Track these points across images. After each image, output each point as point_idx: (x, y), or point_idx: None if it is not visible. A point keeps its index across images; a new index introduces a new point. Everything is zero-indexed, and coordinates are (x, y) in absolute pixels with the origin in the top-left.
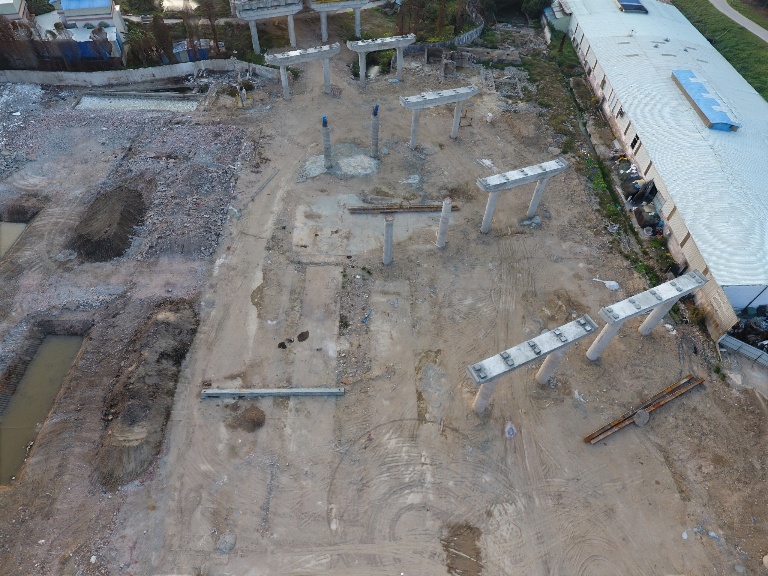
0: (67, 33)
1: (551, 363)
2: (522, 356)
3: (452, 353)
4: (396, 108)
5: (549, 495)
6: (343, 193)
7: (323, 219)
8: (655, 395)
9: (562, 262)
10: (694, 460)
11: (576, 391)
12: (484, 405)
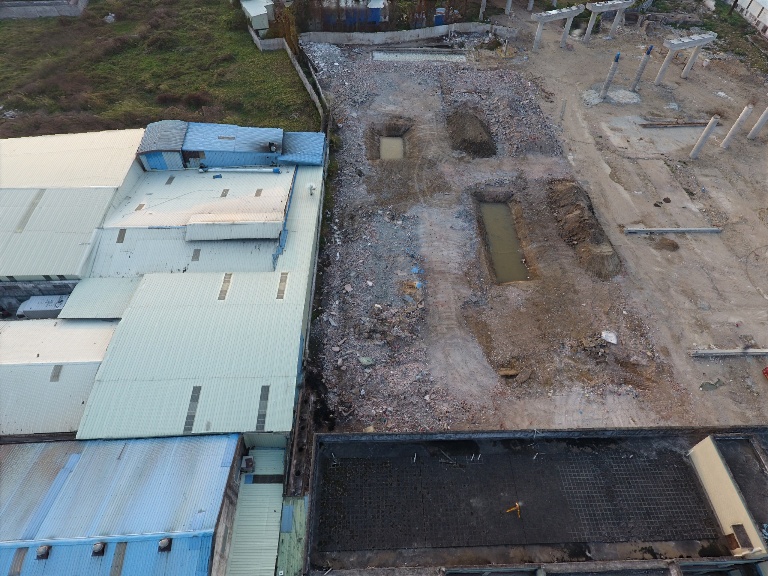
0: None
1: None
2: None
3: None
4: (624, 57)
5: None
6: (627, 115)
7: (625, 131)
8: None
9: None
10: None
11: None
12: None
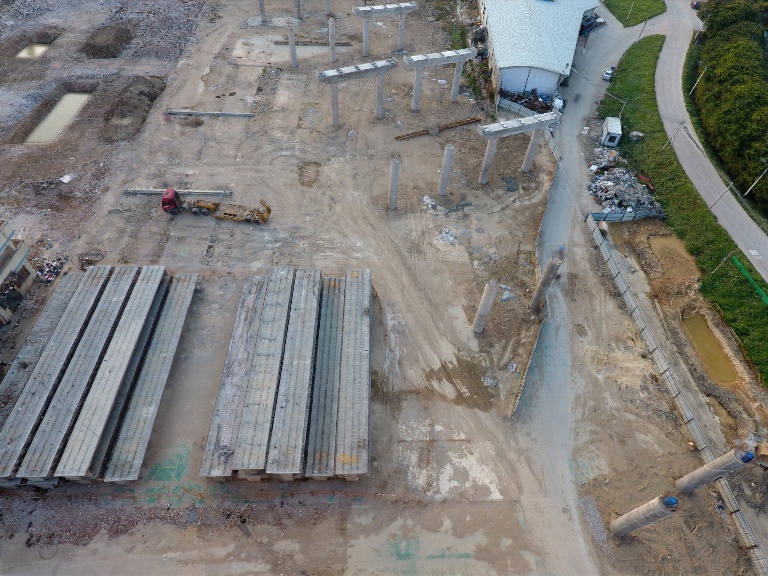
0: None
1: (378, 94)
2: (349, 70)
3: (326, 104)
4: None
5: (366, 155)
6: (272, 34)
7: (255, 46)
8: (447, 124)
9: (413, 71)
10: (459, 148)
11: (399, 121)
12: (336, 117)
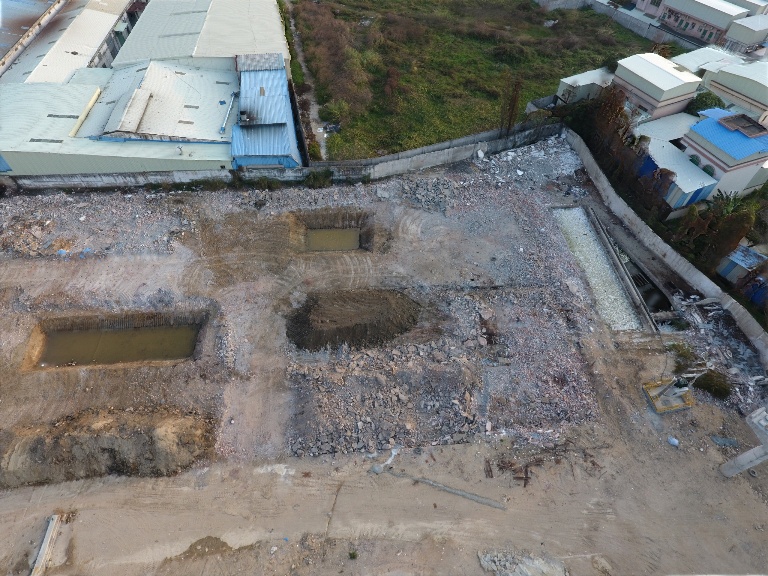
0: (644, 151)
1: None
2: None
3: None
4: None
5: None
6: None
7: None
8: None
9: None
10: None
11: None
12: None
